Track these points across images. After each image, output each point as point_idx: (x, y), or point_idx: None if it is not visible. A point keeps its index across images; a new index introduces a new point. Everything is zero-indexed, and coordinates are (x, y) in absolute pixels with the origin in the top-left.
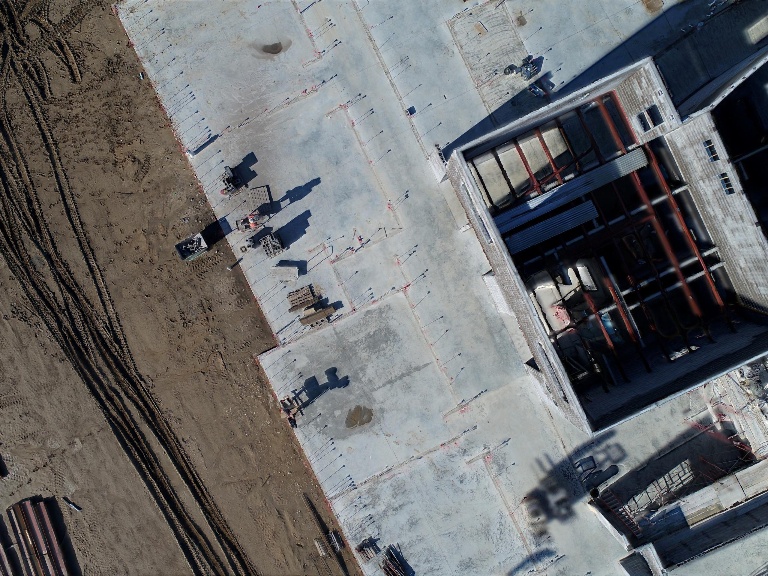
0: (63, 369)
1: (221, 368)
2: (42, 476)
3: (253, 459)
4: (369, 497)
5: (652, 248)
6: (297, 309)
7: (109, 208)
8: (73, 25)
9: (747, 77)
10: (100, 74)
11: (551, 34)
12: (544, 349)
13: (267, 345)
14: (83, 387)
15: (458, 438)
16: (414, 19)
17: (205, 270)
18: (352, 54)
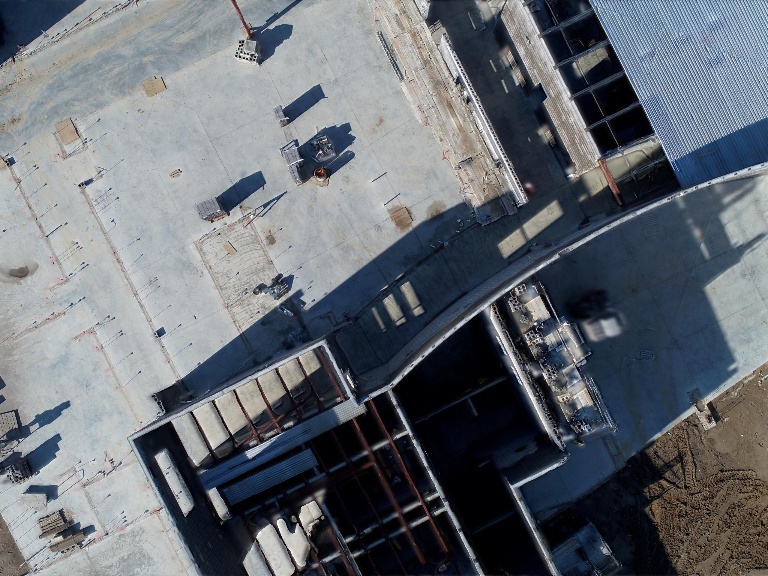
0: None
1: None
2: None
3: None
4: None
5: (409, 464)
6: (48, 535)
7: None
8: None
9: (426, 355)
10: None
11: (301, 252)
12: None
13: (20, 571)
14: None
15: None
16: (162, 240)
17: None
18: (100, 276)
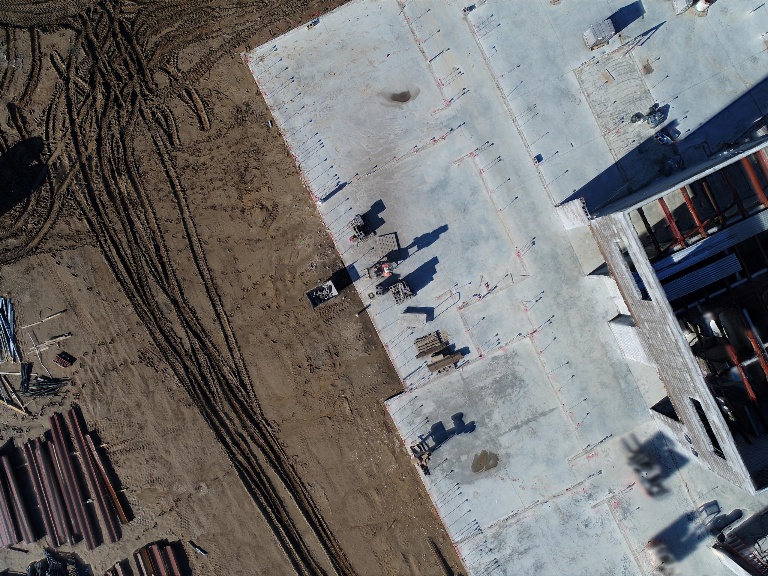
0: (189, 414)
1: (347, 413)
2: (168, 520)
3: (379, 503)
4: (495, 541)
5: None
6: (424, 355)
7: (236, 254)
8: (202, 73)
9: None
10: (229, 122)
11: (677, 82)
12: (702, 406)
13: (393, 390)
14: (209, 432)
15: (583, 483)
16: (542, 68)
17: (332, 316)
18: (480, 102)
